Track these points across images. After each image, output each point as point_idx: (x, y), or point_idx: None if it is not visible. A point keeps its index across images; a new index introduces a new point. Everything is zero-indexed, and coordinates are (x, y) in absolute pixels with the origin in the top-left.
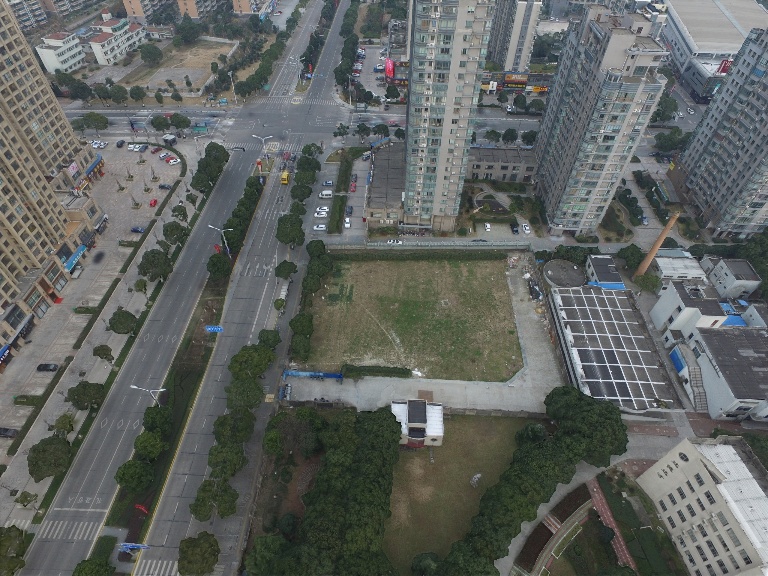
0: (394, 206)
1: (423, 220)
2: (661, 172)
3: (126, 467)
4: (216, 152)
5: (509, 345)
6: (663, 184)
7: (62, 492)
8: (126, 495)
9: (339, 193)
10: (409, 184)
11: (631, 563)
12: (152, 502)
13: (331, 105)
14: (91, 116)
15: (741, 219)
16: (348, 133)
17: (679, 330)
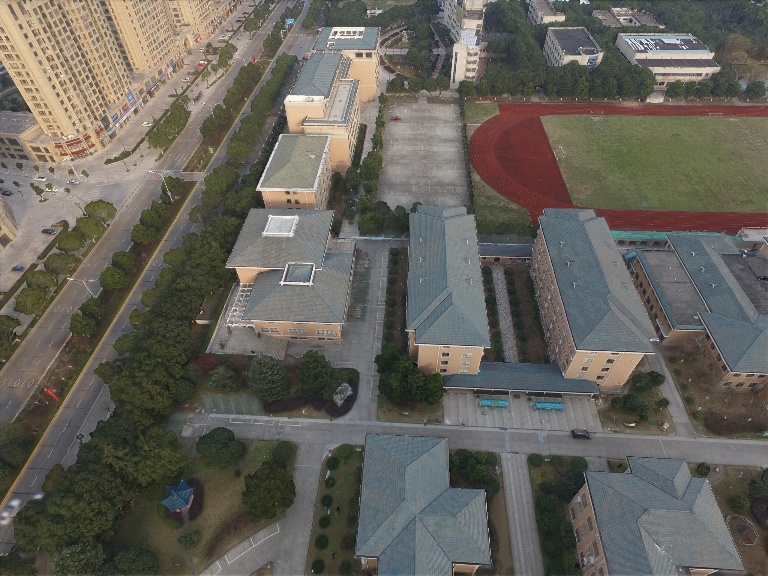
0: None
1: None
2: None
3: None
4: None
5: None
6: None
7: (262, 28)
8: None
9: None
10: None
11: (434, 31)
12: None
13: None
14: None
15: None
16: None
17: None
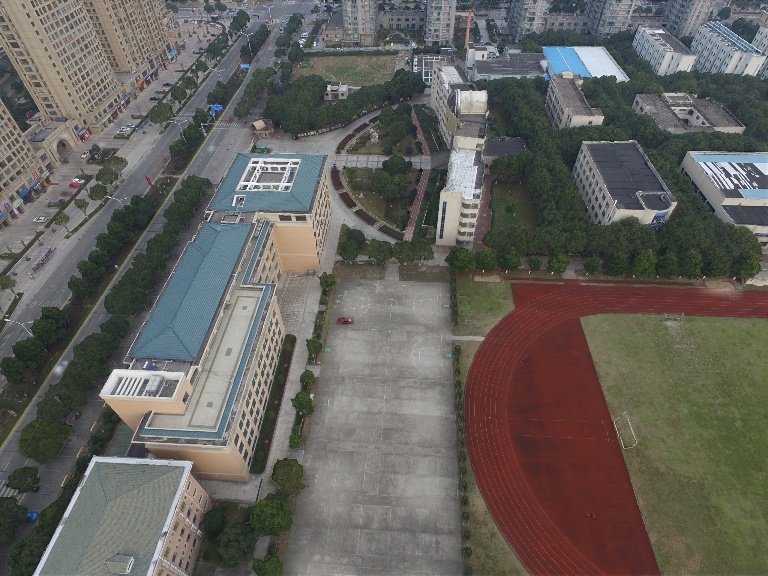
0: (339, 30)
1: (355, 38)
2: (504, 25)
3: (211, 92)
4: (243, 15)
5: (389, 78)
6: (503, 29)
7: None
8: (210, 110)
9: (312, 35)
10: (344, 12)
11: (417, 121)
12: (221, 112)
13: (313, 4)
14: (170, 4)
15: (526, 30)
16: (320, 11)
17: (472, 67)
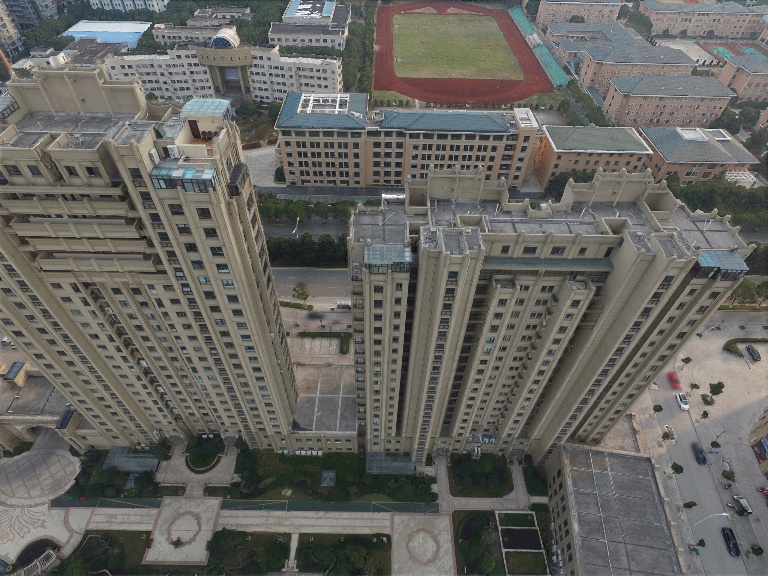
0: None
1: None
2: None
3: None
4: None
5: None
6: None
7: None
8: None
9: None
10: None
11: None
12: None
13: None
14: None
15: (8, 38)
16: None
17: None
